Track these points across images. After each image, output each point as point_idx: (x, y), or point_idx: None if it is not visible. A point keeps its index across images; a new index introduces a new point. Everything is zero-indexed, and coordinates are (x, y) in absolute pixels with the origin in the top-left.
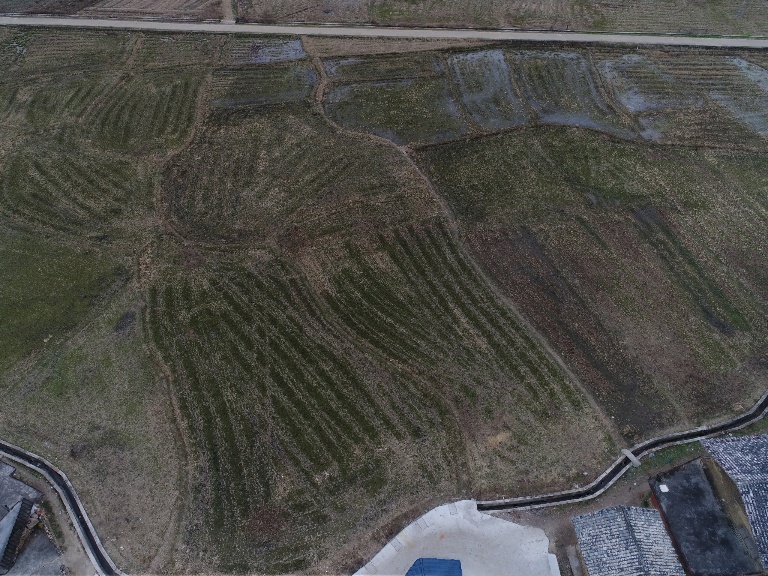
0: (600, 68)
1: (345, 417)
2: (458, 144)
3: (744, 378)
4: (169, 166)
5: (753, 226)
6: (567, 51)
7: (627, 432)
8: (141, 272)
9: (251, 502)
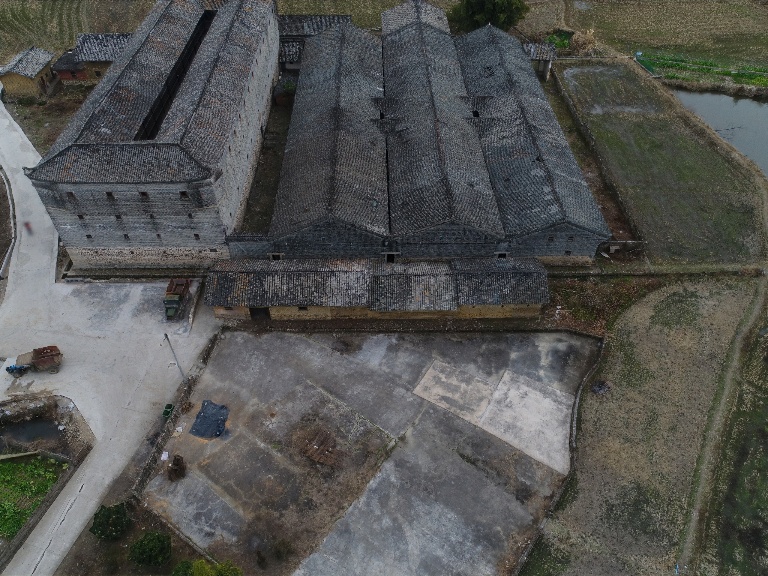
0: None
1: None
2: None
3: None
4: None
5: None
6: None
7: None
8: None
9: None
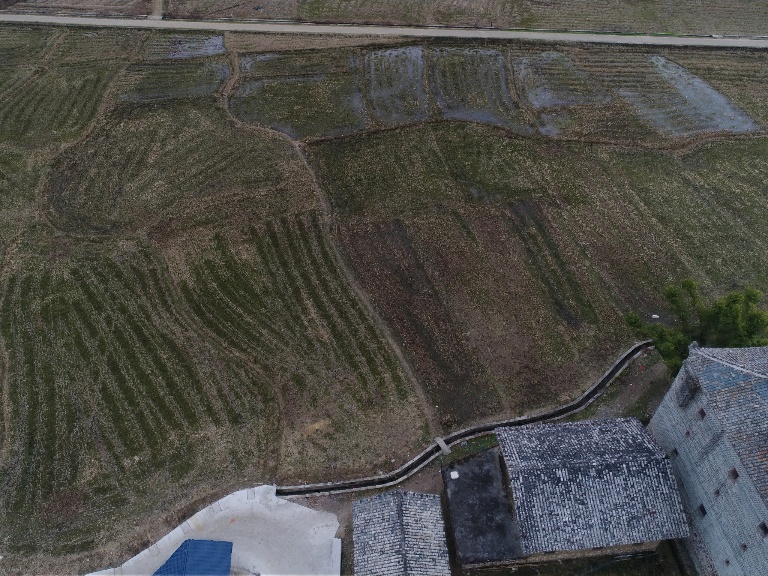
0: (516, 65)
1: (170, 404)
2: (354, 139)
3: (578, 369)
4: (60, 158)
5: (628, 221)
6: (487, 48)
7: (446, 421)
8: (4, 261)
9: (55, 485)
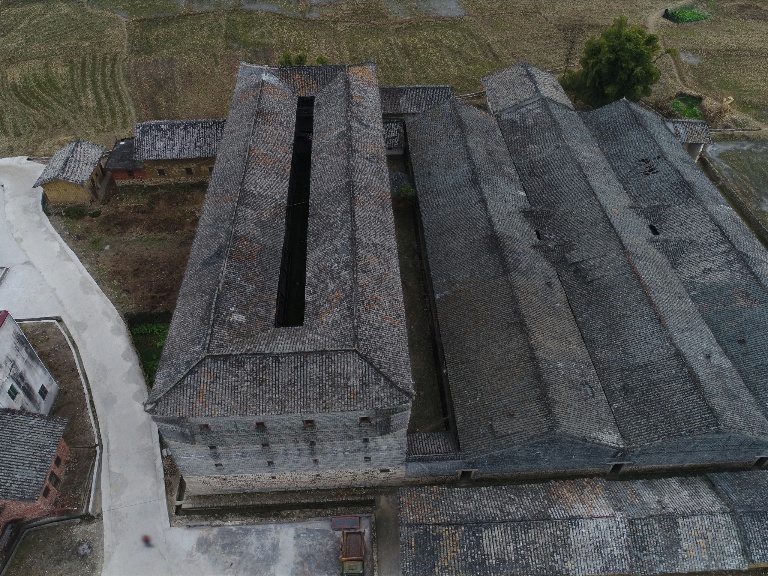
0: None
1: None
2: (168, 19)
3: None
4: None
5: None
6: None
7: None
8: None
9: None
